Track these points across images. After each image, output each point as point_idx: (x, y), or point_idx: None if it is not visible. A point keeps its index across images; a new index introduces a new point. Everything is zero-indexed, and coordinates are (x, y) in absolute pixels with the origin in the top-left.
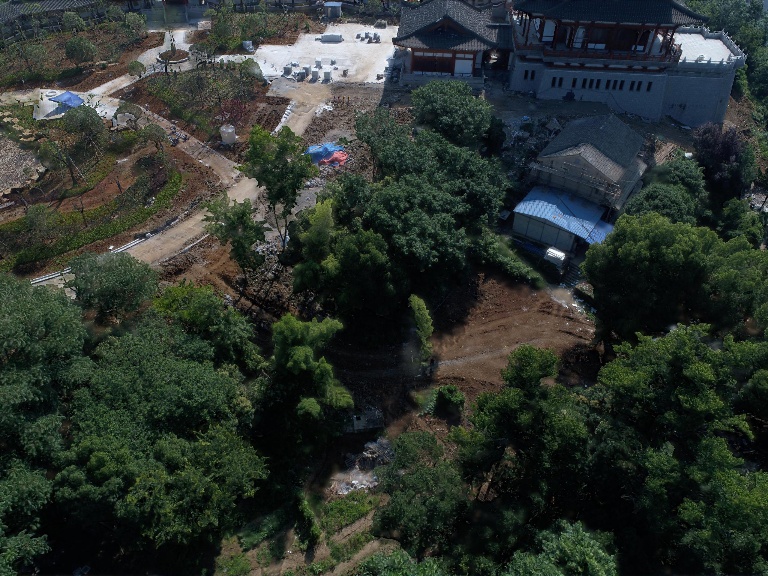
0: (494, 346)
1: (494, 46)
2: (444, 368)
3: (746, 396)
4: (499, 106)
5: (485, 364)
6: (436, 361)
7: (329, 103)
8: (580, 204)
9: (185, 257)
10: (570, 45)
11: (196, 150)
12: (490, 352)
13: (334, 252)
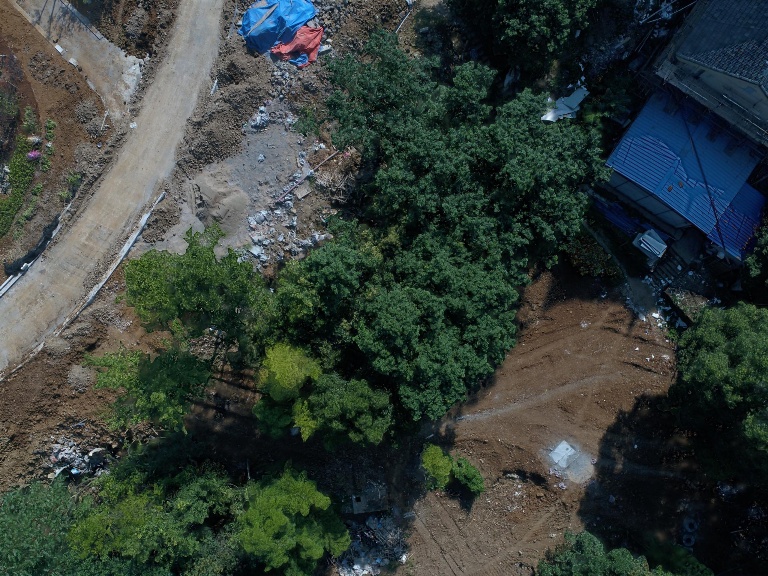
0: (532, 390)
1: None
2: (463, 425)
3: None
4: None
5: (516, 418)
6: (454, 415)
7: None
8: (723, 147)
9: (92, 316)
10: None
11: (42, 8)
12: (525, 399)
13: (310, 401)
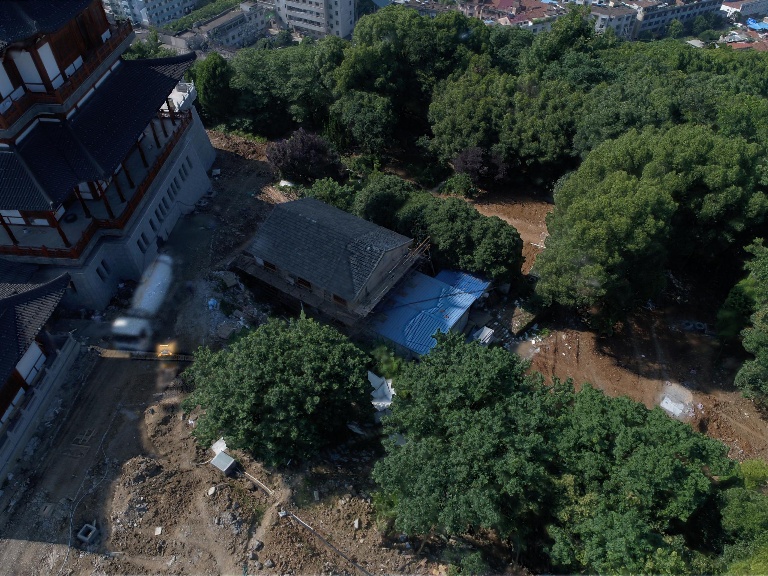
0: None
1: (65, 283)
2: None
3: (746, 225)
4: (155, 333)
5: None
6: None
7: None
8: (410, 289)
9: None
10: (98, 194)
11: None
12: None
13: None
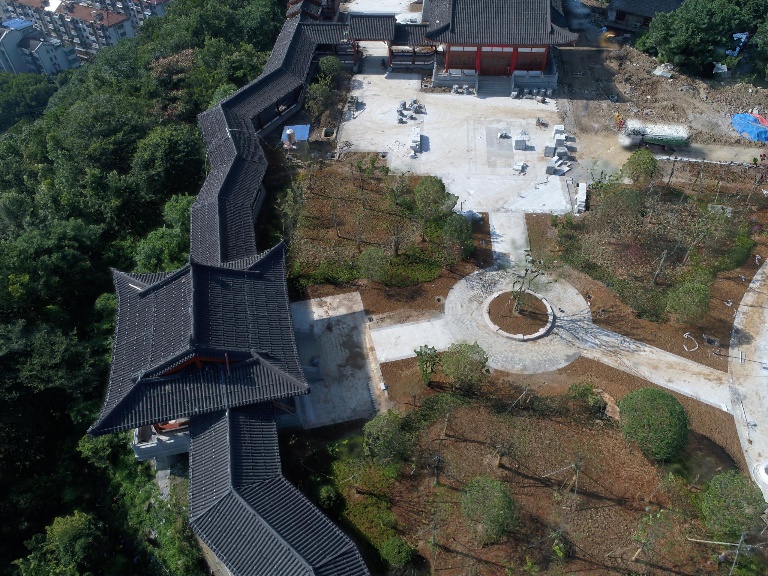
0: None
1: None
2: None
3: None
4: (580, 41)
5: None
6: None
7: (629, 132)
8: None
9: None
10: None
11: None
12: None
13: None
